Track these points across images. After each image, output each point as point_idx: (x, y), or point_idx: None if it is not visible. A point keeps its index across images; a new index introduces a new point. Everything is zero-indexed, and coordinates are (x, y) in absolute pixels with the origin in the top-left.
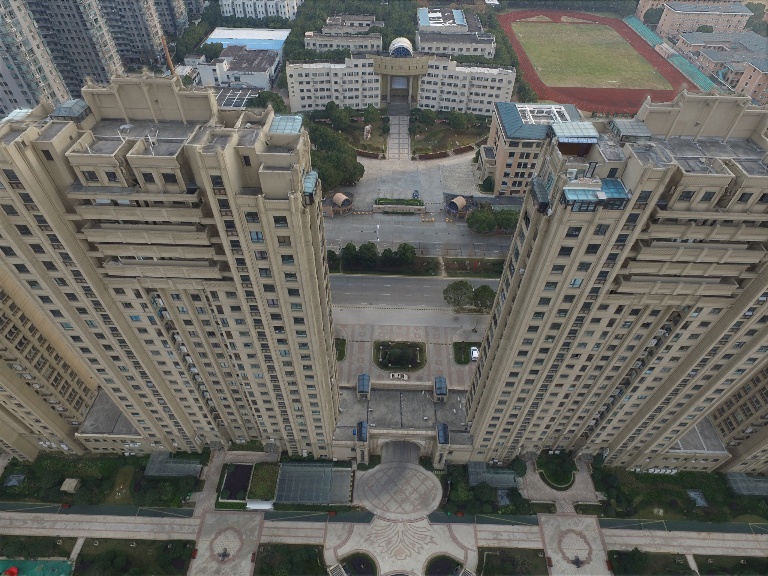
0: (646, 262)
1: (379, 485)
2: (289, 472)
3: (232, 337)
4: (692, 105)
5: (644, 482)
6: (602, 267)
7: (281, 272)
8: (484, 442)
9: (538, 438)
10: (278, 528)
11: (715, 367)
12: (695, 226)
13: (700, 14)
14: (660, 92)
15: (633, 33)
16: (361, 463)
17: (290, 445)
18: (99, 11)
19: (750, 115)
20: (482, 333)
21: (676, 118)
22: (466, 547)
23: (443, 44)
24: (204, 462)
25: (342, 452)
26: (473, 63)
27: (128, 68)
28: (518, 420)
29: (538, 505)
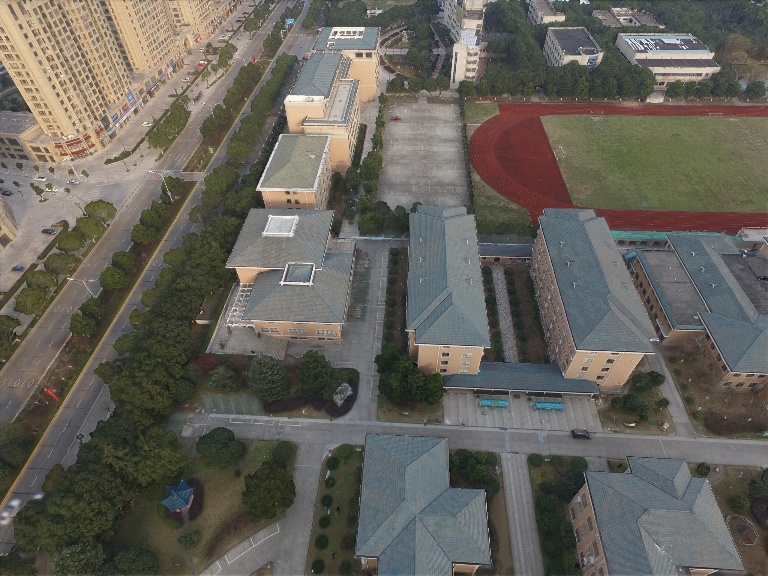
0: None
1: None
2: None
3: None
4: None
5: None
6: None
7: None
8: None
9: None
10: None
11: None
12: None
13: None
14: (558, 190)
15: None
16: None
17: None
18: None
19: None
20: None
21: None
22: None
23: None
24: None
25: None
26: None
27: None
28: None
29: None
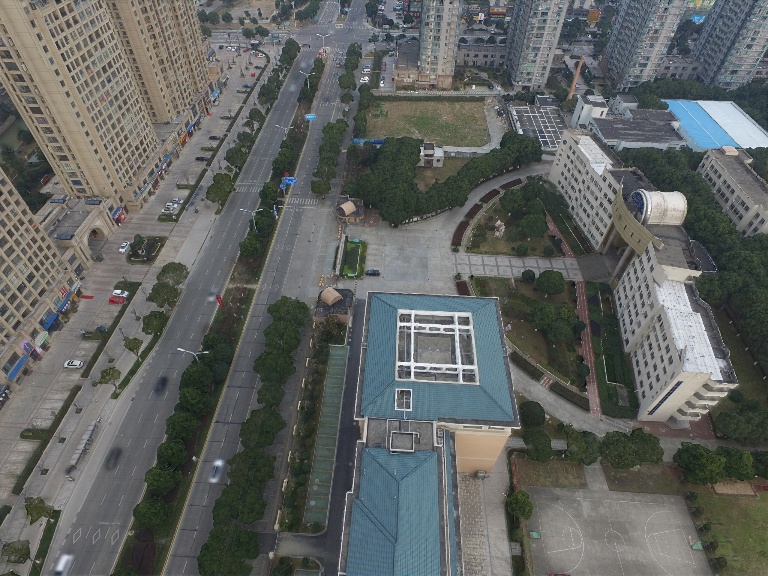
0: None
1: None
2: None
3: None
4: None
5: None
6: None
7: None
8: None
9: None
10: None
11: None
12: None
13: None
14: None
15: None
16: None
17: None
18: (558, 9)
19: None
20: (143, 305)
21: None
22: None
23: None
24: None
25: None
26: None
27: None
28: None
29: None
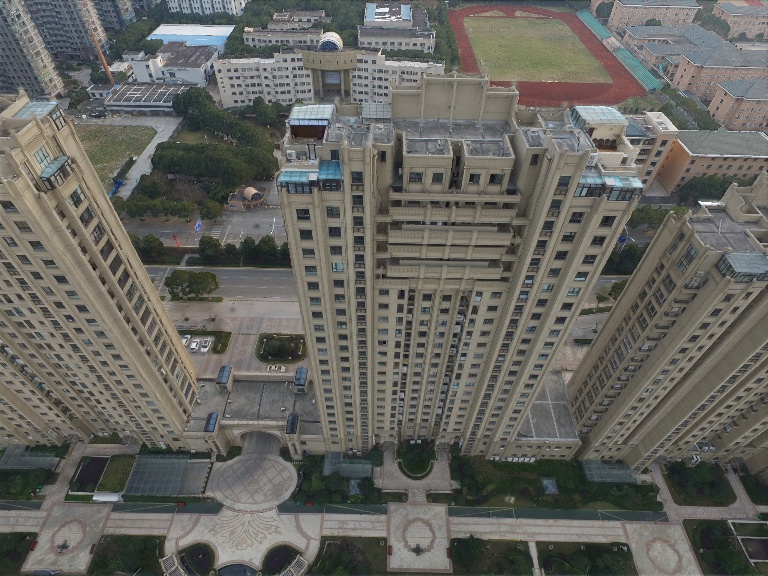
0: (403, 245)
1: (235, 476)
2: (144, 464)
3: (35, 327)
4: (438, 87)
5: (501, 470)
6: (354, 251)
7: (37, 258)
8: (332, 432)
9: (390, 427)
10: (124, 520)
11: (521, 352)
12: (433, 208)
13: (648, 8)
14: (599, 85)
15: (584, 27)
16: (219, 454)
17: (145, 437)
18: (22, 7)
19: (499, 97)
20: None
21: (421, 100)
22: (309, 536)
23: (382, 39)
24: (61, 455)
25: (197, 443)
26: (404, 57)
27: (65, 65)
28: (355, 409)
29: (390, 494)
